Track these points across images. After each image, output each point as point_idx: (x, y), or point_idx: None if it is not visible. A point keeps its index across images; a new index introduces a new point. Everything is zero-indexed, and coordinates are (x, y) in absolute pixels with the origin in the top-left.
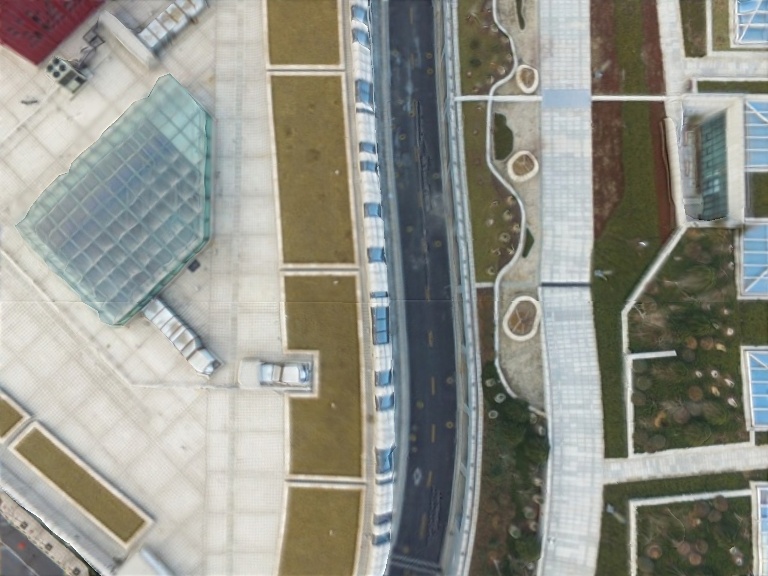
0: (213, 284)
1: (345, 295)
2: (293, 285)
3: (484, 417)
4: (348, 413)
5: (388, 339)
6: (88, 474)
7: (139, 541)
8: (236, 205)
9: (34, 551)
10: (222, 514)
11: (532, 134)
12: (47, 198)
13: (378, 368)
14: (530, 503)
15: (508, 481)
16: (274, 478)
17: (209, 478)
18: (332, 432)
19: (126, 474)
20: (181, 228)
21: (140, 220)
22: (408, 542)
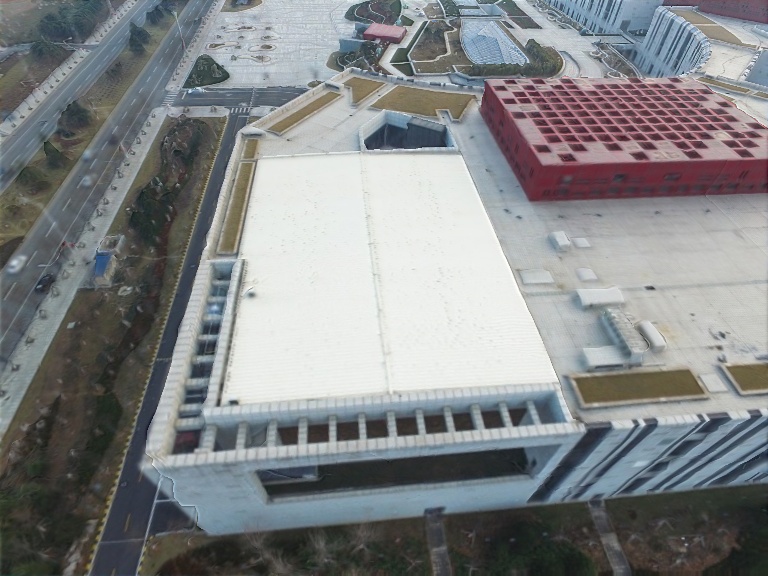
0: None
1: None
2: None
3: None
4: None
5: None
6: None
7: None
8: None
9: None
10: None
11: None
12: None
13: None
14: None
15: None
16: None
17: None
18: None
19: None
20: None
21: None
22: None
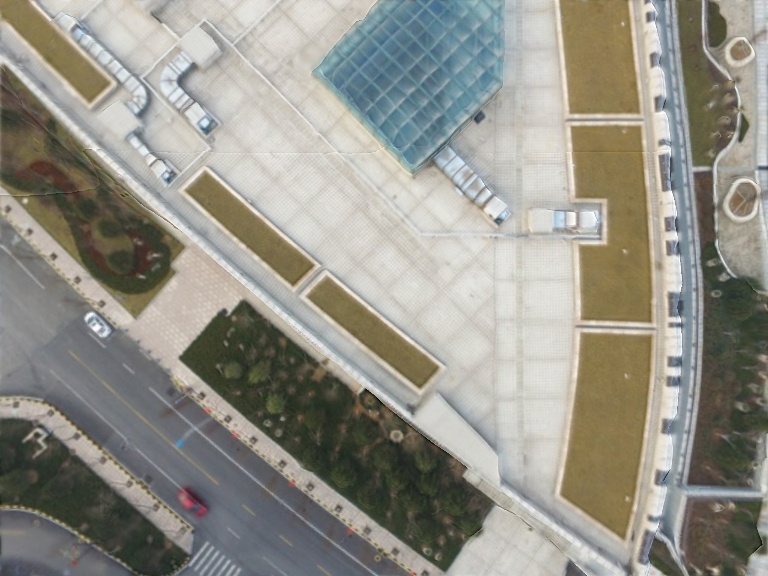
0: (497, 136)
1: (631, 145)
2: (580, 135)
3: (704, 298)
4: (638, 260)
5: None
6: (381, 321)
7: (433, 387)
8: (518, 58)
9: (238, 445)
10: (512, 361)
11: (745, 22)
12: (345, 43)
13: (671, 213)
14: (756, 379)
15: (732, 359)
16: (563, 326)
17: (498, 326)
18: (622, 279)
19: (416, 323)
20: (482, 72)
21: (440, 64)
22: None
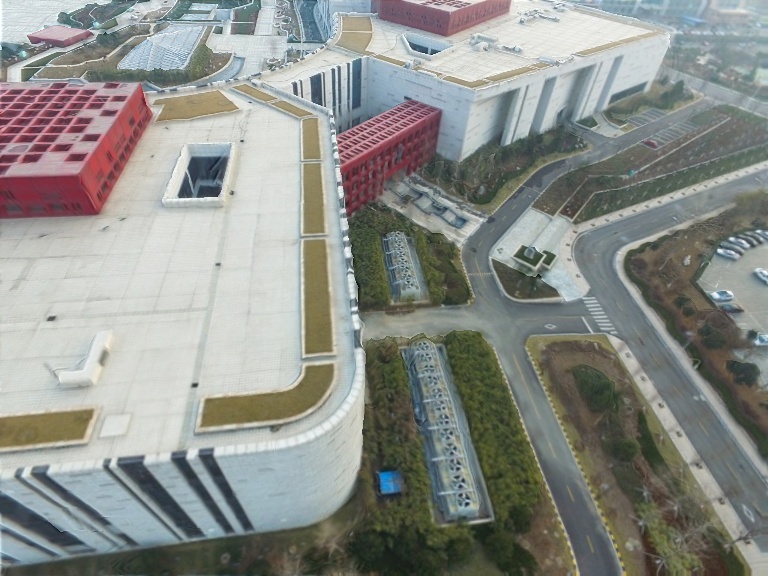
0: None
1: None
2: None
3: None
4: None
5: None
6: None
7: None
8: None
9: None
10: None
11: (276, 21)
12: None
13: None
14: None
15: None
16: None
17: None
18: None
19: None
20: None
21: None
22: (313, 3)
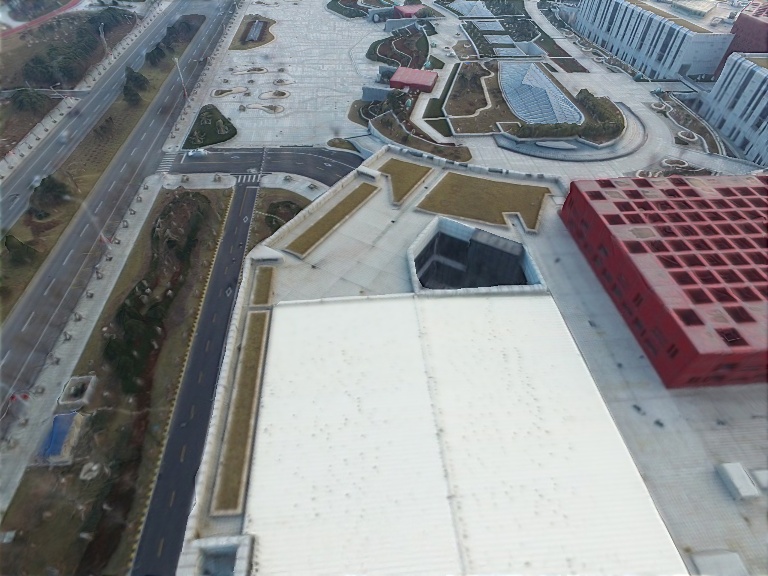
0: None
1: None
2: None
3: None
4: None
5: (614, 6)
6: None
7: None
8: None
9: None
10: None
11: None
12: None
13: None
14: None
15: None
16: None
17: None
18: None
19: None
20: (679, 1)
21: None
22: None
